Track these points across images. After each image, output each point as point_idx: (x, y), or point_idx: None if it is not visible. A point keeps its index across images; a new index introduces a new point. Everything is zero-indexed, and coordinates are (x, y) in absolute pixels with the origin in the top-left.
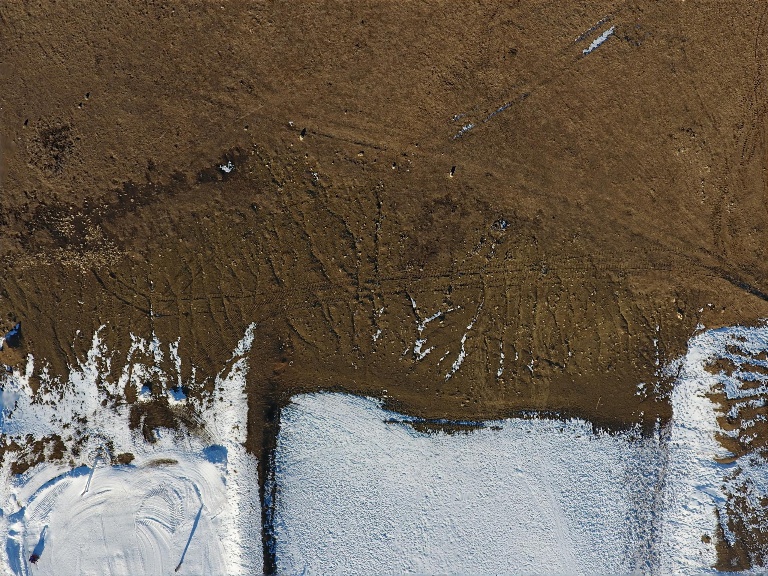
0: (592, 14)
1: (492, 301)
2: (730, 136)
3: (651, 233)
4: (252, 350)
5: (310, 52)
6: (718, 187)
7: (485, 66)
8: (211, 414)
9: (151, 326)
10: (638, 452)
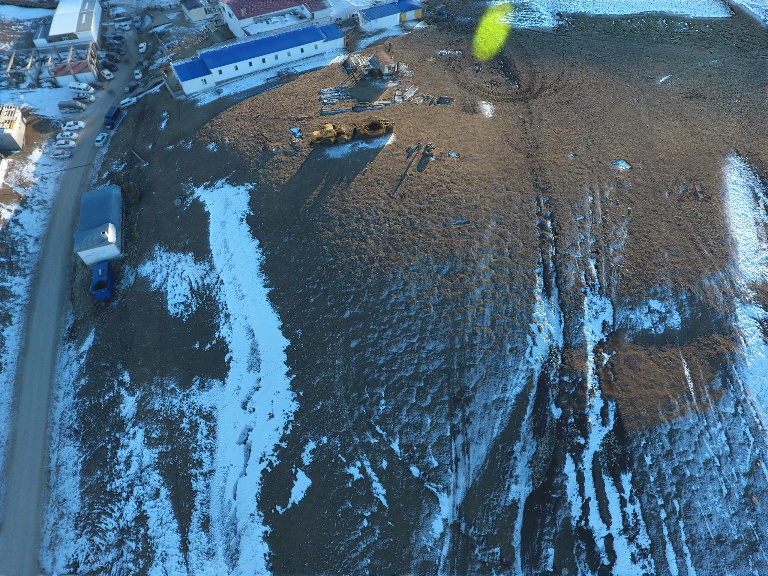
0: None
1: None
2: None
3: None
4: (764, 21)
5: None
6: None
7: None
8: None
9: None
10: None
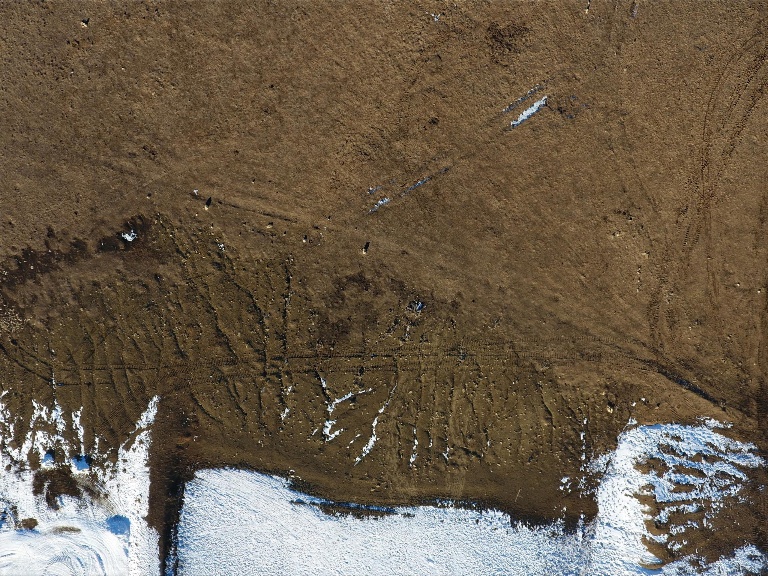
0: (523, 82)
1: (405, 385)
2: (672, 221)
3: (580, 321)
4: (155, 423)
5: (216, 117)
6: (656, 275)
7: (404, 136)
8: (114, 485)
9: (53, 394)
10: (559, 549)
